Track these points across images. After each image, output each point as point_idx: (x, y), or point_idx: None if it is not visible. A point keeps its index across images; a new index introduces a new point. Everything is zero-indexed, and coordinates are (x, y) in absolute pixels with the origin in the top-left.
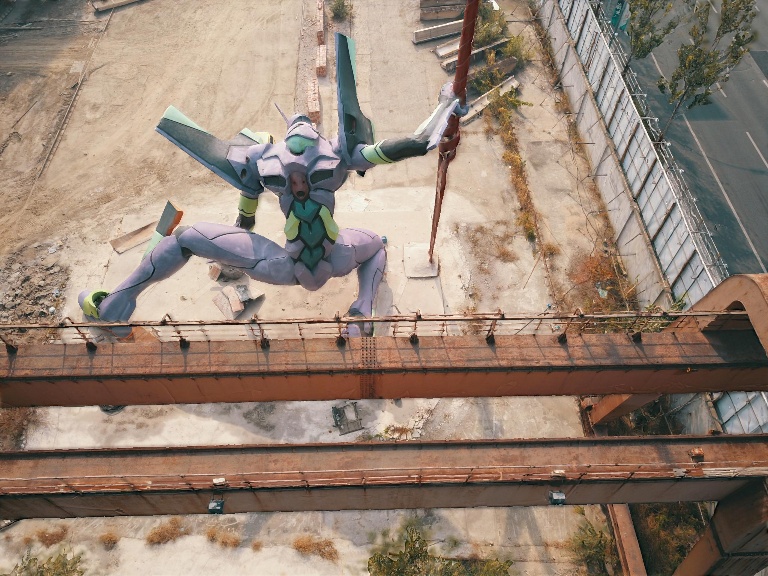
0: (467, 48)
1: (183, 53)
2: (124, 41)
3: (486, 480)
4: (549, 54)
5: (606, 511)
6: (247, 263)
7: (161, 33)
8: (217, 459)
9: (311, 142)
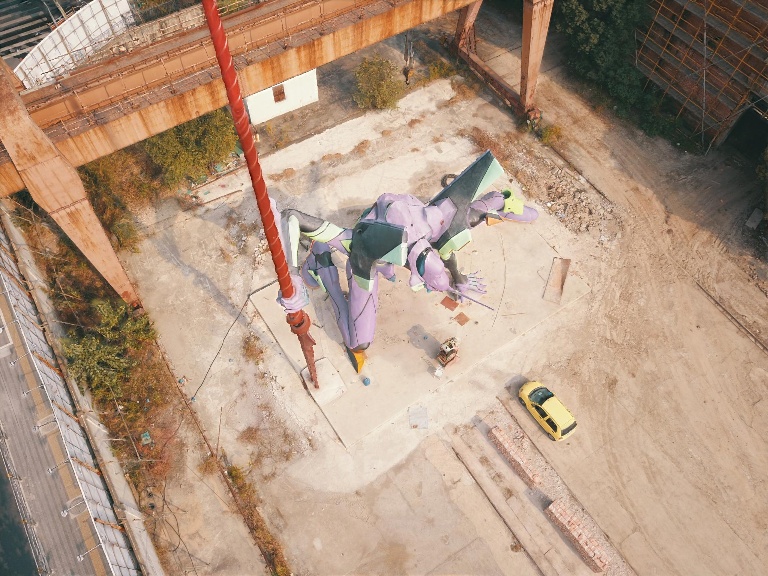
0: None
1: None
2: None
3: None
4: None
5: None
6: None
7: None
8: None
9: None
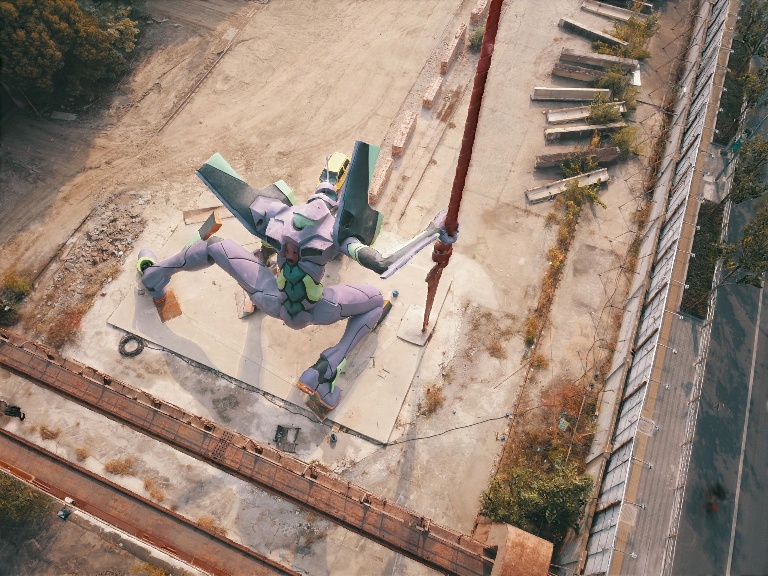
0: (456, 196)
1: (320, 46)
2: (277, 19)
3: None
4: (659, 155)
5: None
6: (249, 288)
7: (311, 19)
8: (82, 480)
9: (312, 222)
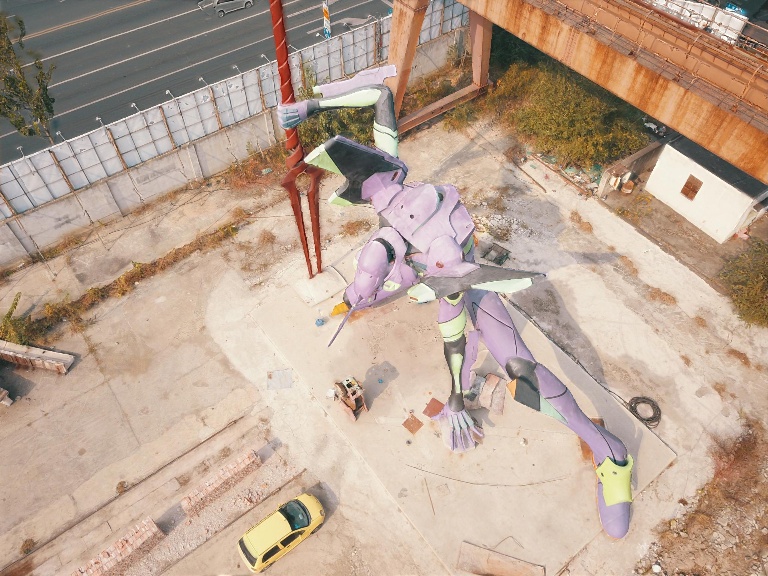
0: None
1: None
2: None
3: None
4: None
5: (430, 125)
6: None
7: None
8: None
9: None
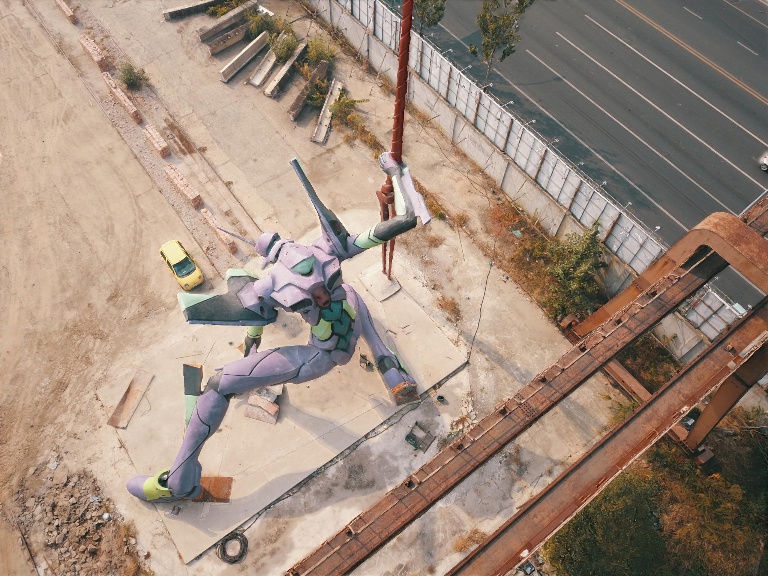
0: (401, 127)
1: (4, 197)
2: None
3: (652, 440)
4: (347, 44)
5: (617, 387)
6: (290, 375)
7: None
8: (502, 541)
9: (313, 258)
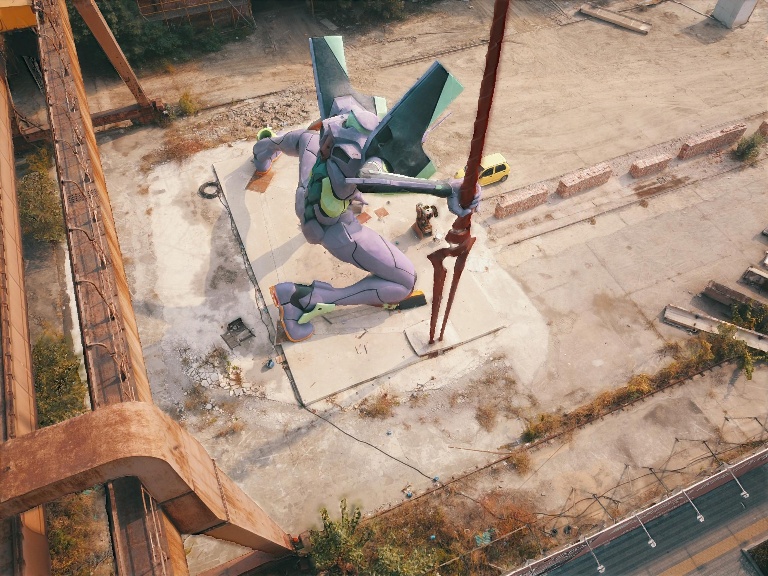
0: (473, 147)
1: (577, 77)
2: (560, 40)
3: None
4: None
5: None
6: None
7: (590, 54)
8: None
9: (359, 127)
